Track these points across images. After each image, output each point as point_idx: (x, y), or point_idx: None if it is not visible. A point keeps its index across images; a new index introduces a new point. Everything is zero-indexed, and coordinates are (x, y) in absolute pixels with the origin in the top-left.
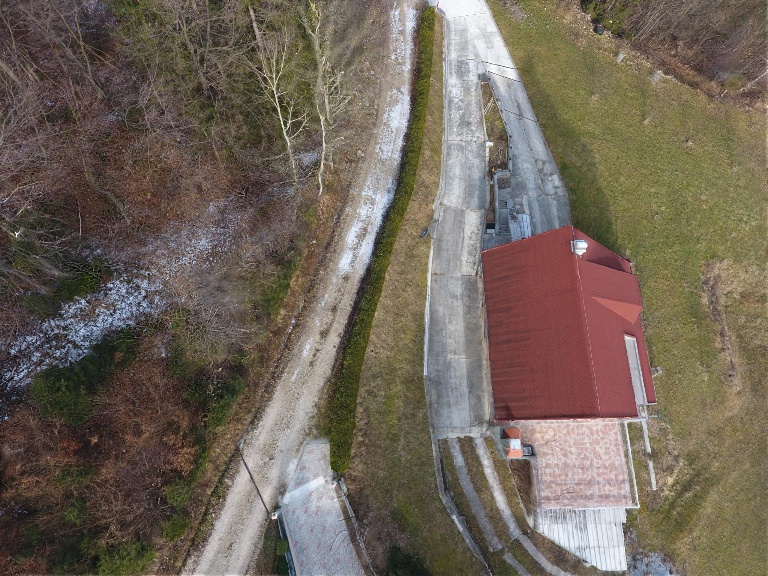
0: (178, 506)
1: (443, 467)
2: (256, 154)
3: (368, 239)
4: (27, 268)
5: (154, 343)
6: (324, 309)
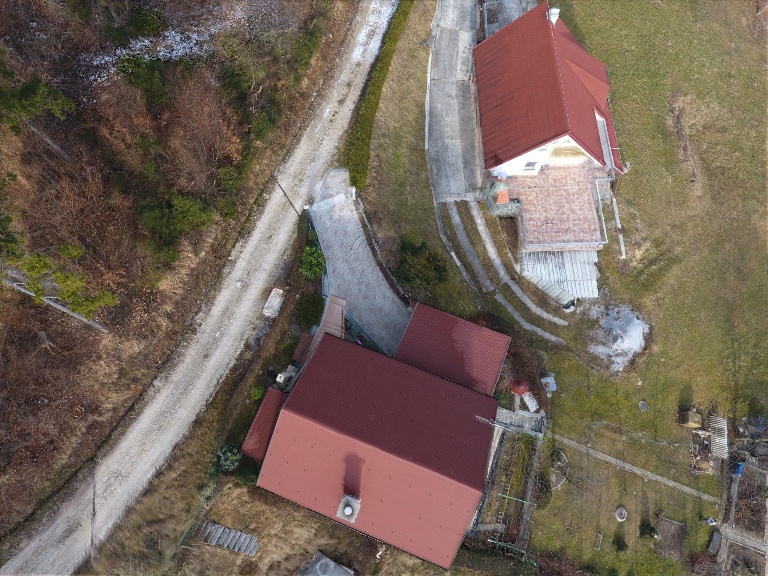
0: (230, 189)
1: (443, 224)
2: None
3: (376, 38)
4: None
5: (205, 75)
6: (340, 85)
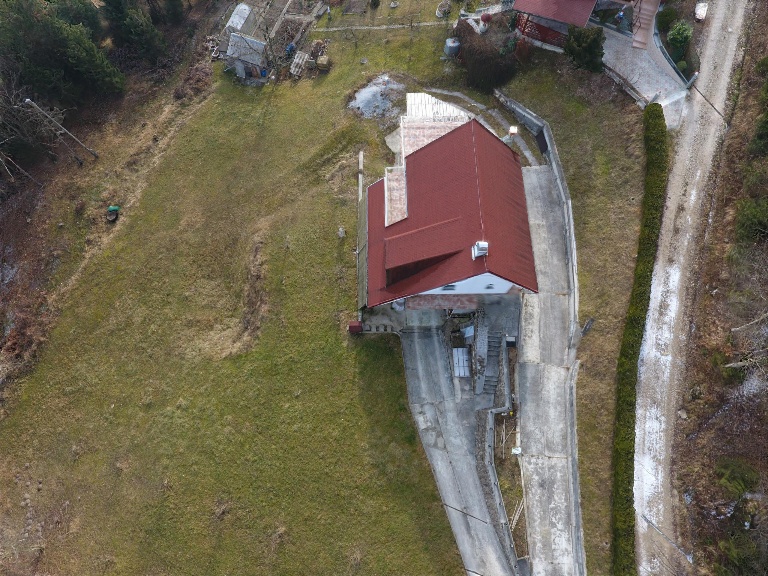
0: None
1: (540, 149)
2: None
3: (656, 303)
4: None
5: None
6: (686, 231)
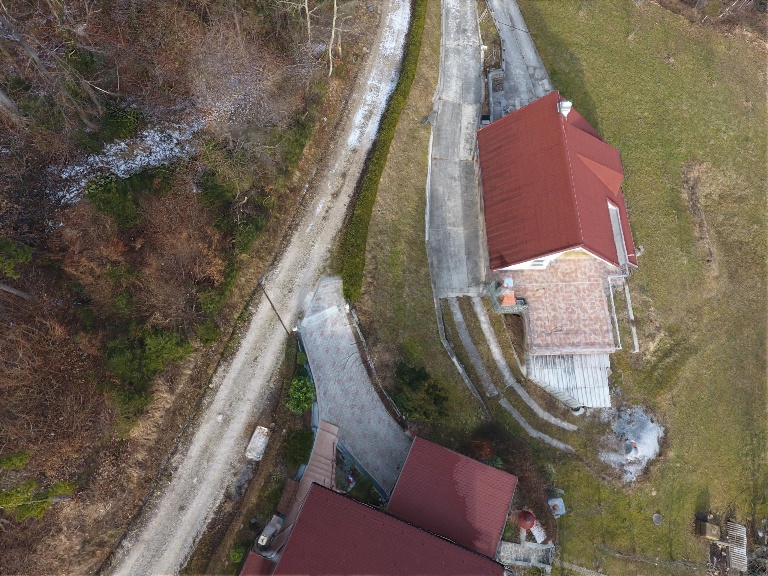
0: (211, 313)
1: (444, 322)
2: (271, 39)
3: (374, 119)
4: (78, 95)
5: (186, 181)
6: (335, 175)
